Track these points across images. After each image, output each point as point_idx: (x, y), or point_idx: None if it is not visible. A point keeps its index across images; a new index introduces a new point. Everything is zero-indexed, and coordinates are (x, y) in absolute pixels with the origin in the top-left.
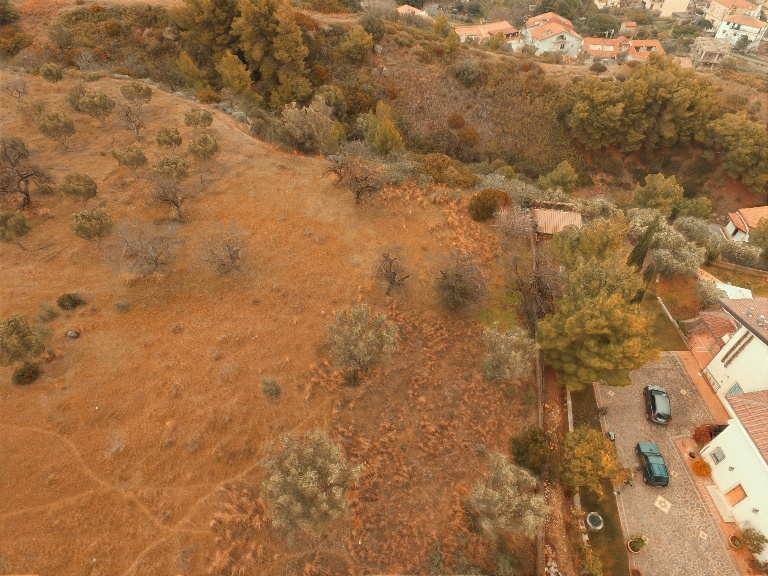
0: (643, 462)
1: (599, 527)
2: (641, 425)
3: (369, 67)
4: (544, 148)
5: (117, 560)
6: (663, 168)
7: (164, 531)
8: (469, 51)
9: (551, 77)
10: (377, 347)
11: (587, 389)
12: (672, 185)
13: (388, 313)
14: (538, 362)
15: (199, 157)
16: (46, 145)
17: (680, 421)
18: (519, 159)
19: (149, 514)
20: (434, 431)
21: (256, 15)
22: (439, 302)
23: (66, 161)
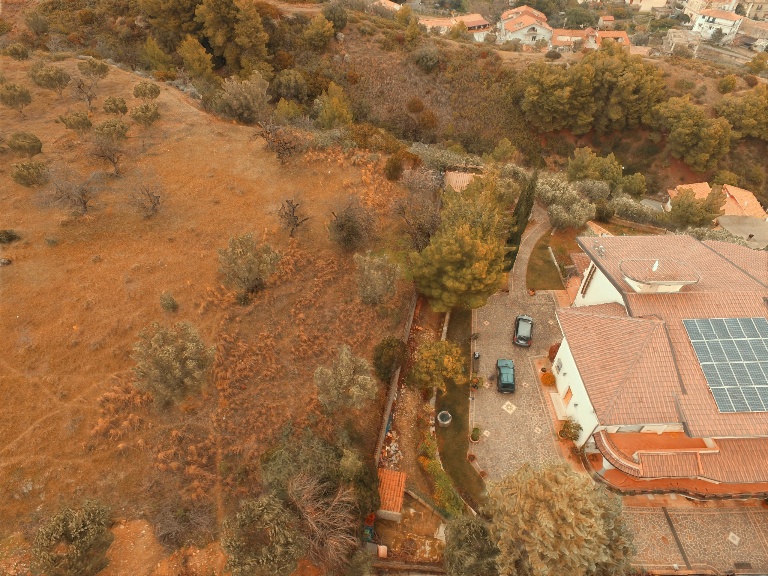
0: (497, 374)
1: (447, 422)
2: (506, 347)
3: (331, 54)
4: (499, 131)
5: (17, 424)
6: (613, 150)
7: (60, 405)
8: (430, 39)
9: (508, 64)
10: (255, 265)
11: (466, 320)
12: (608, 161)
13: (288, 250)
14: (414, 291)
15: (141, 123)
16: (6, 114)
17: (542, 344)
18: (475, 141)
19: (49, 393)
20: (307, 340)
21: (217, 2)
22: (332, 240)
23: (22, 127)
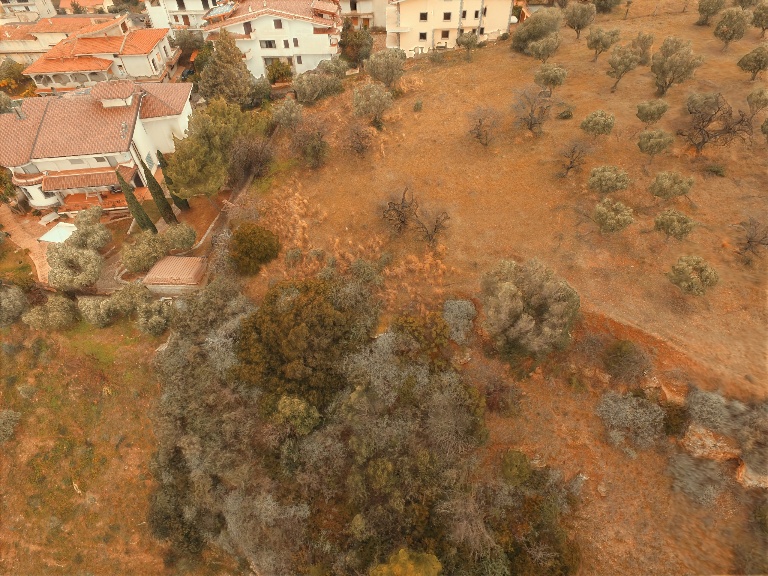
0: None
1: None
2: None
3: None
4: None
5: None
6: None
7: None
8: None
9: None
10: None
11: None
12: None
13: None
14: None
15: None
16: None
17: None
18: None
19: None
20: None
21: None
22: None
23: (765, 208)
